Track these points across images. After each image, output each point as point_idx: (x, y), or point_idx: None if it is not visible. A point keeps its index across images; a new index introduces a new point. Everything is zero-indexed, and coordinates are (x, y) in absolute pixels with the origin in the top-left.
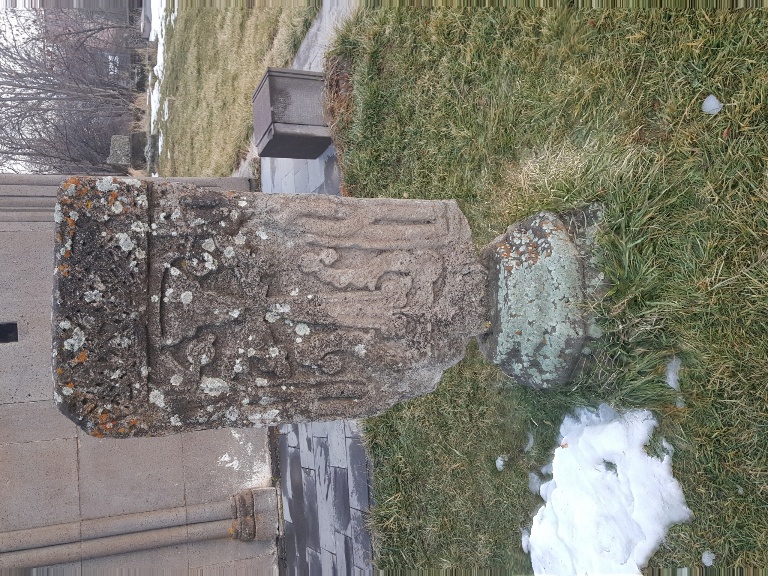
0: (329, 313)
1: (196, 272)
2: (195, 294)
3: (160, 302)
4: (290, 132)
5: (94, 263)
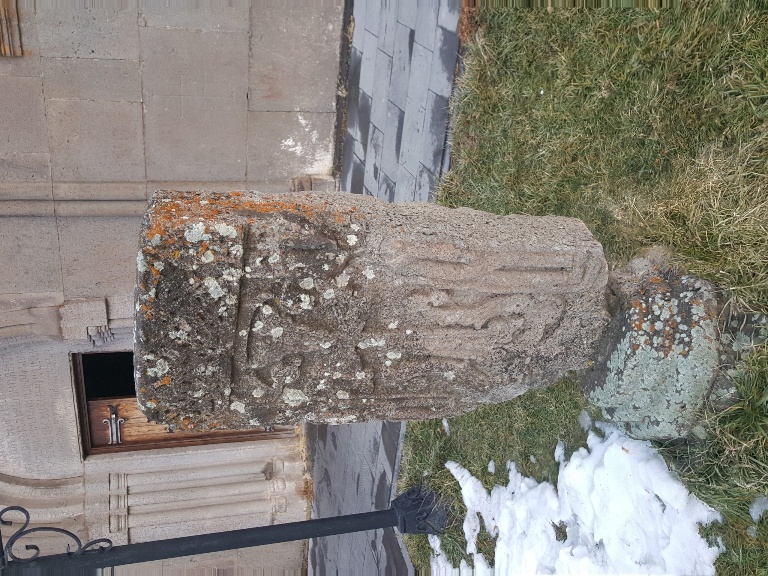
0: (425, 347)
1: (290, 311)
2: (286, 330)
3: (248, 335)
4: None
5: (180, 308)
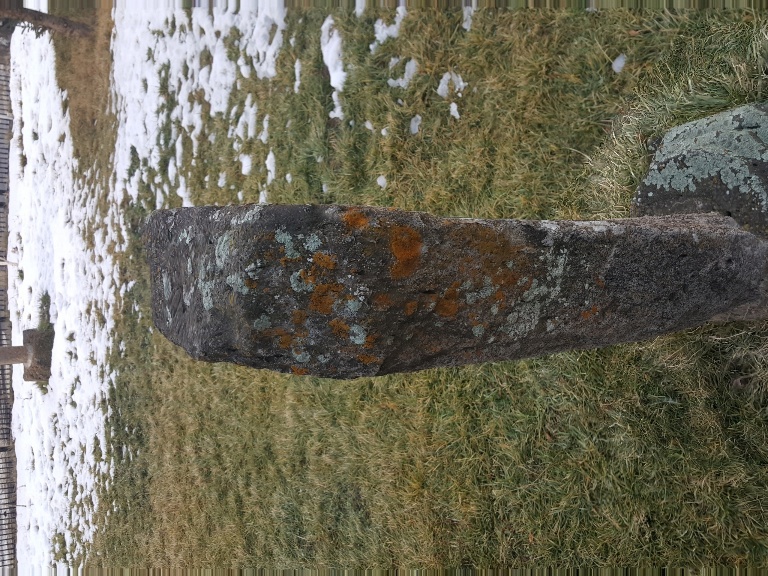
0: None
1: None
2: None
3: None
4: None
5: None
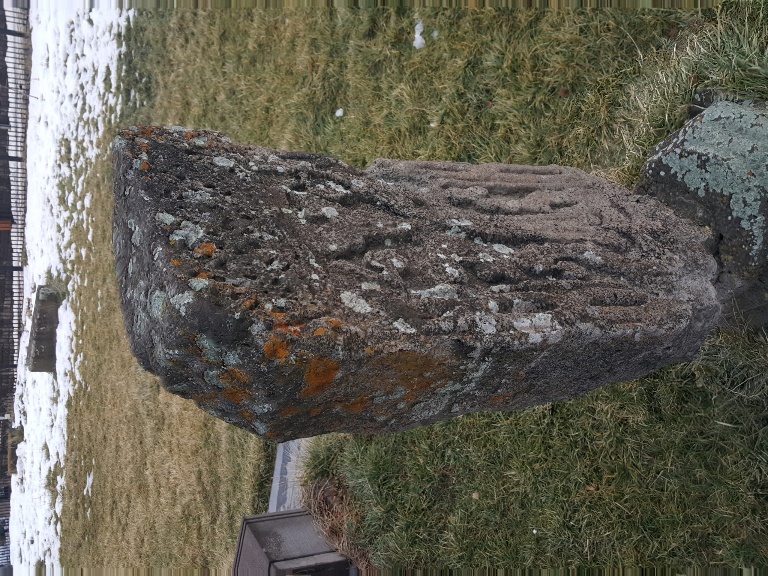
0: (522, 228)
1: (328, 195)
2: (339, 210)
3: None
4: (297, 574)
5: (185, 172)
